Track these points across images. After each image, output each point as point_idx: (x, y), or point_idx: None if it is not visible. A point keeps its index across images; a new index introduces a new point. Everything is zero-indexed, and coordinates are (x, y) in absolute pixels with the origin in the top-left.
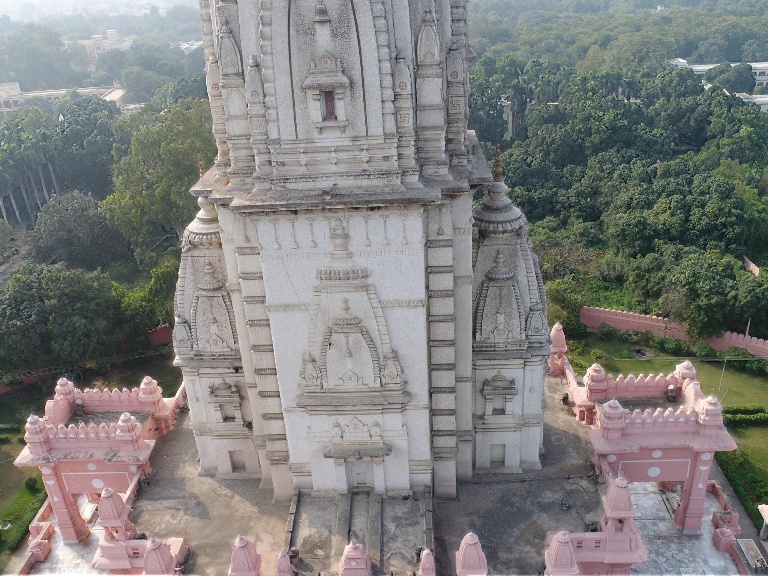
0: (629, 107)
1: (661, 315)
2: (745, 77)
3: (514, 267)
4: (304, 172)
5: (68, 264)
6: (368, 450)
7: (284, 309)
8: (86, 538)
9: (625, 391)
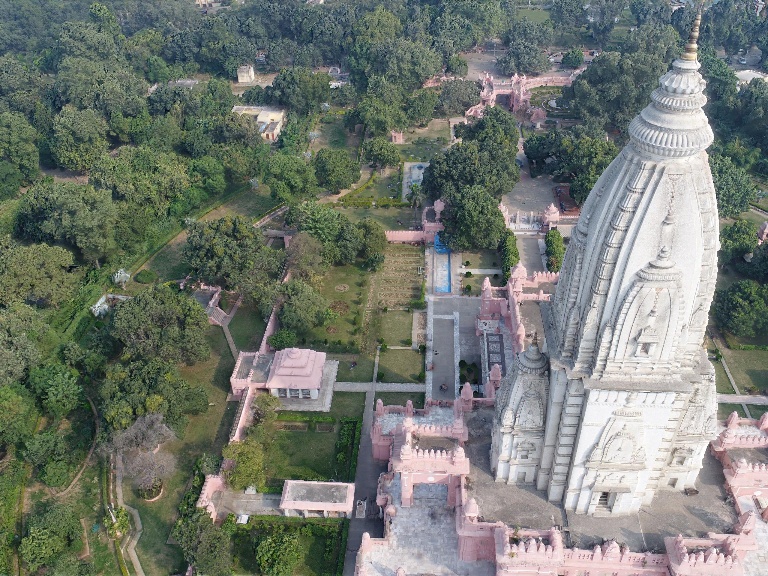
0: None
1: None
2: None
3: None
4: None
5: None
6: None
7: None
8: None
9: None
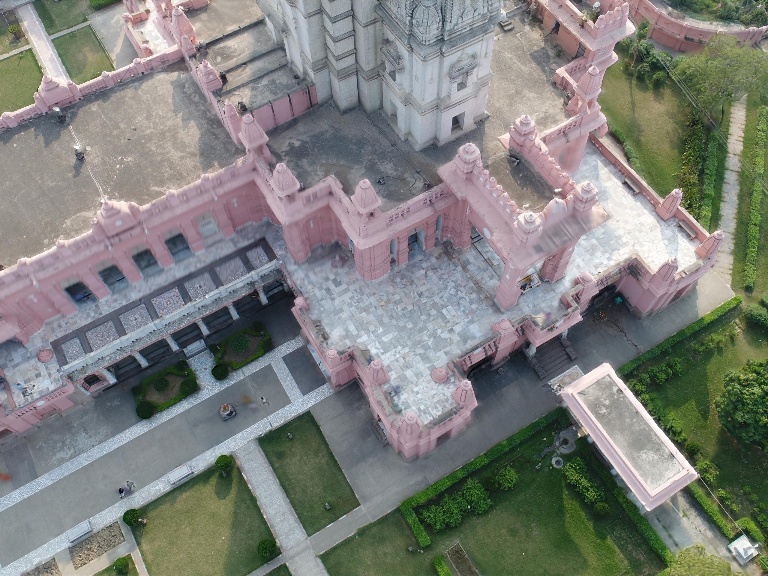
0: None
1: None
2: None
3: None
4: None
5: None
6: (274, 18)
7: None
8: None
9: (535, 161)
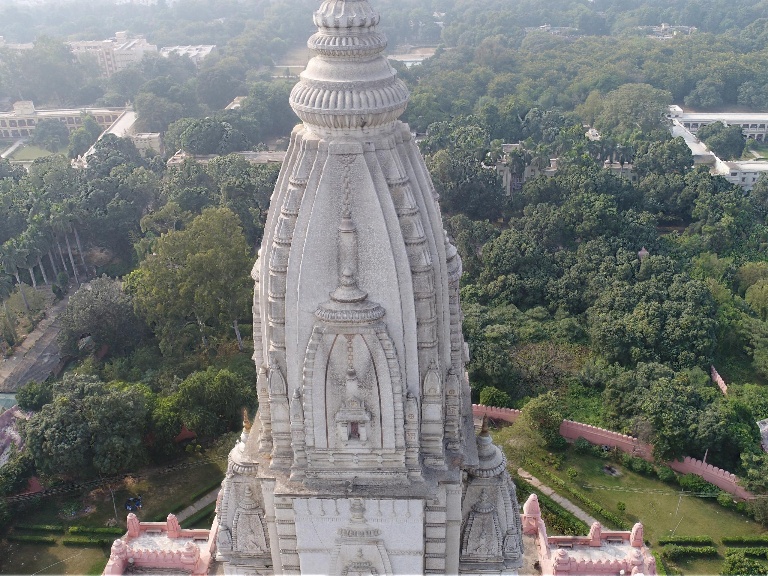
0: (621, 182)
1: (631, 435)
2: (735, 139)
3: (495, 502)
4: (332, 467)
5: (96, 345)
6: None
7: (311, 552)
8: None
9: (585, 571)
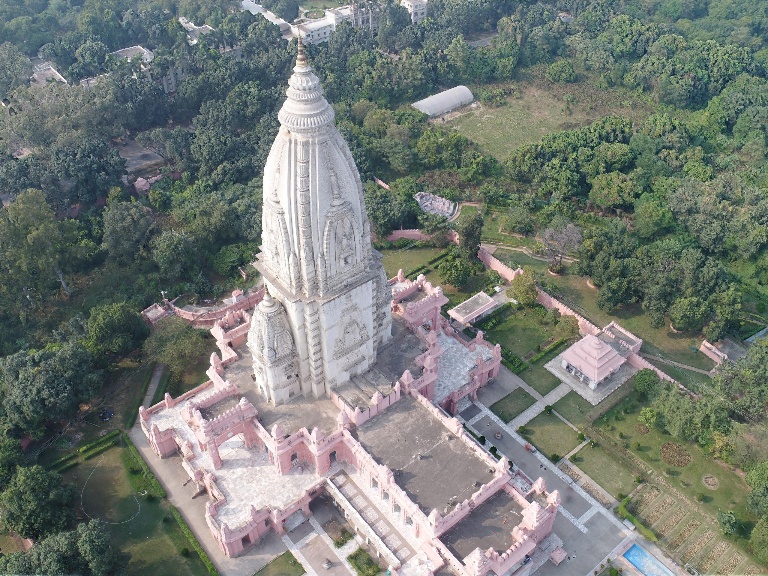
0: (248, 66)
1: None
2: (292, 5)
3: None
4: (338, 282)
5: None
6: (358, 361)
7: None
8: (223, 463)
9: (405, 294)
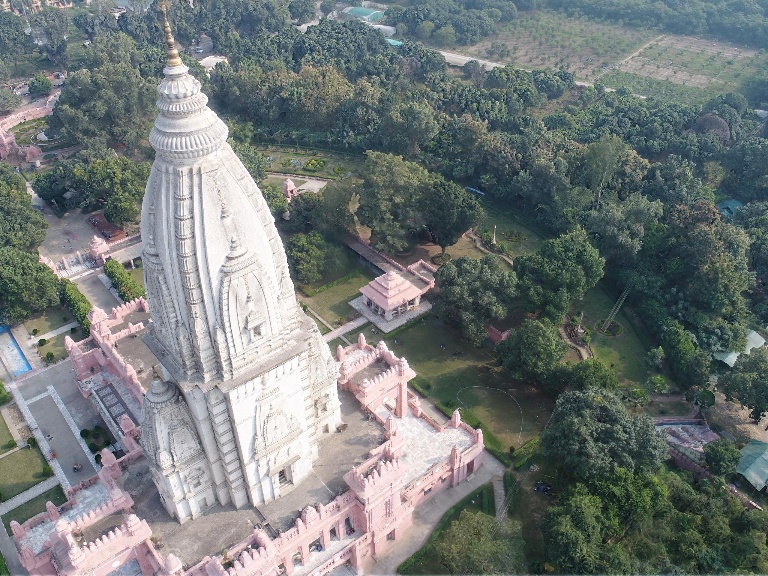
0: None
1: None
2: None
3: None
4: None
5: None
6: None
7: None
8: None
9: None
